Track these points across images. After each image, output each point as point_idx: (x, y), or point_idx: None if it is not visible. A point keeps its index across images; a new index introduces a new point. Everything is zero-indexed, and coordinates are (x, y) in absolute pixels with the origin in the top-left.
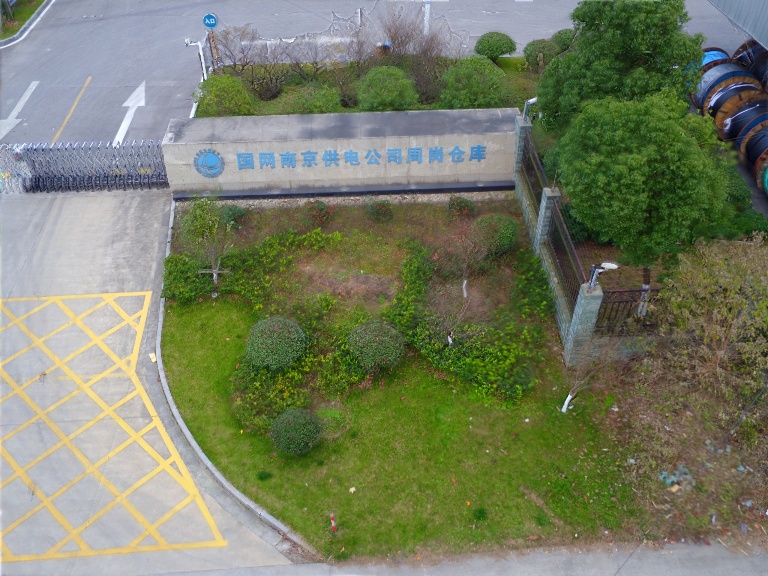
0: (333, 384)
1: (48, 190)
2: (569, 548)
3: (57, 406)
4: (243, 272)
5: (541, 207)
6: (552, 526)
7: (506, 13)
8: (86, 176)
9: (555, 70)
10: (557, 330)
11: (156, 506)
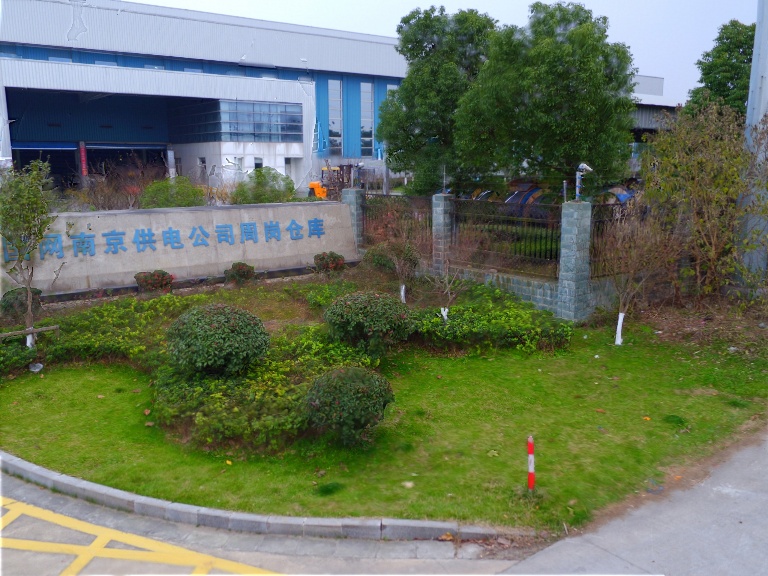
0: None
1: None
2: None
3: None
4: (79, 333)
5: (435, 218)
6: (755, 403)
7: None
8: None
9: (391, 104)
10: None
11: None
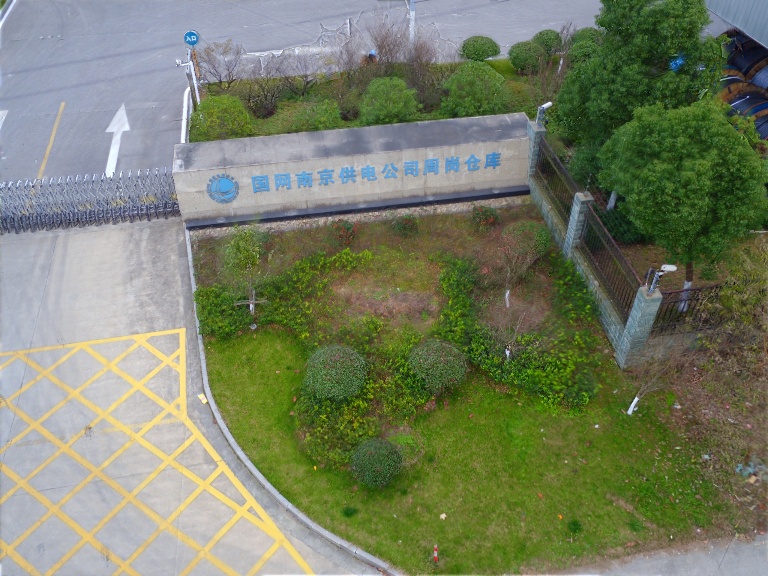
0: (401, 409)
1: (47, 228)
2: (668, 551)
3: (111, 461)
4: (280, 300)
5: (573, 212)
6: (646, 530)
7: (476, 15)
8: (87, 210)
9: (576, 76)
10: (604, 332)
11: (243, 557)
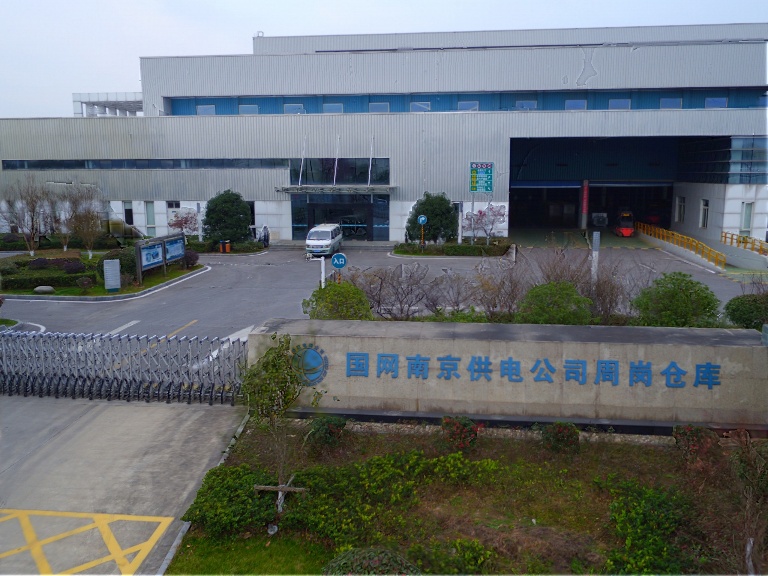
0: None
1: (92, 396)
2: None
3: None
4: (328, 497)
5: None
6: None
7: None
8: (145, 383)
9: None
10: None
11: None
